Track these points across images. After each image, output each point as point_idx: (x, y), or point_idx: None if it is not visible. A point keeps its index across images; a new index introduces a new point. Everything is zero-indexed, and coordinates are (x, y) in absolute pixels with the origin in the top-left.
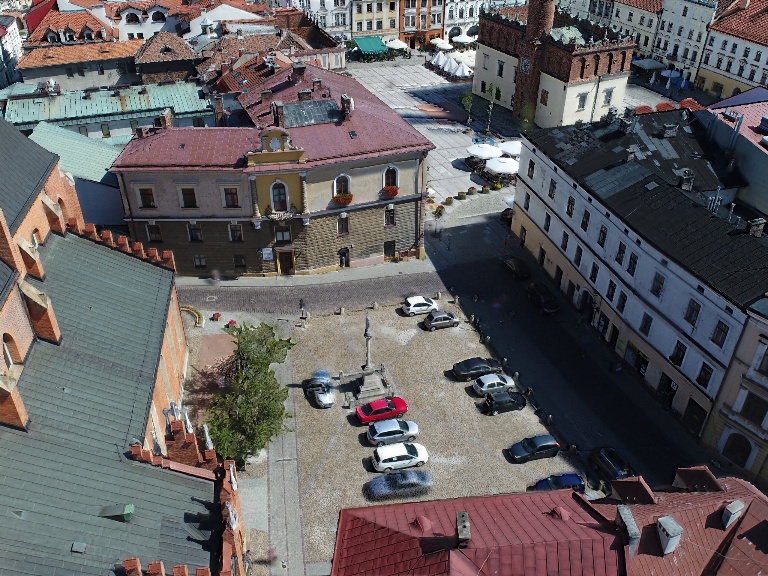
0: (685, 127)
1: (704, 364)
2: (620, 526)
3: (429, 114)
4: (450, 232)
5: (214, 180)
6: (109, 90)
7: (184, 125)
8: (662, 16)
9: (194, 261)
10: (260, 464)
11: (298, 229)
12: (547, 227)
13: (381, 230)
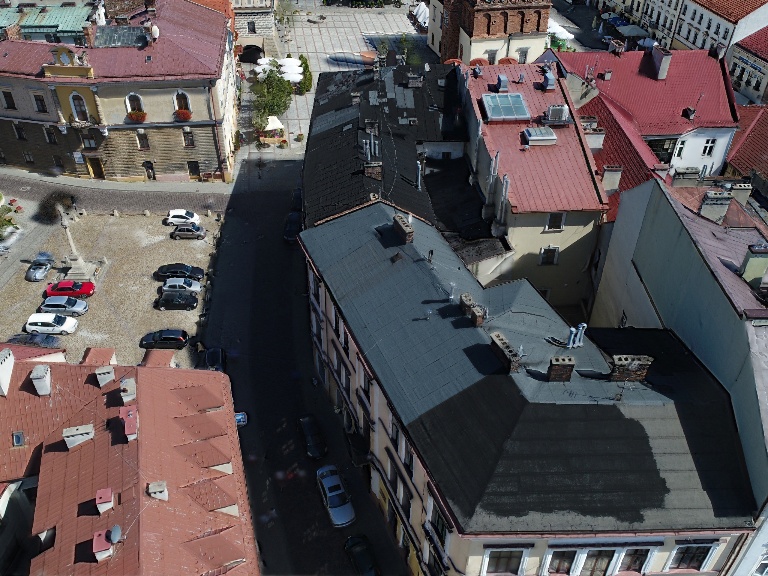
0: (440, 80)
1: None
2: None
3: (365, 60)
4: (276, 164)
5: (24, 86)
6: (18, 7)
7: (67, 42)
8: None
9: (25, 157)
10: None
11: (100, 138)
12: None
13: (182, 150)
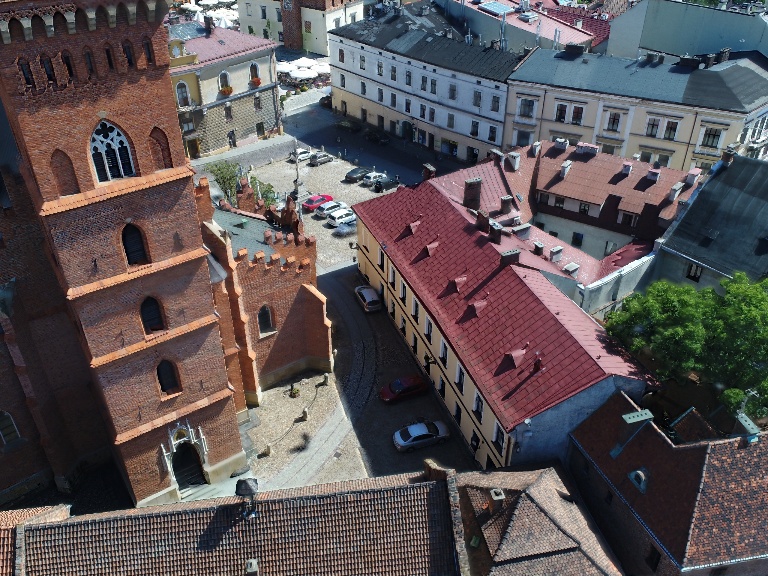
0: (432, 9)
1: (491, 127)
2: (494, 158)
3: None
4: (290, 119)
5: None
6: None
7: None
8: None
9: None
10: None
11: (199, 119)
12: (363, 92)
13: (253, 114)
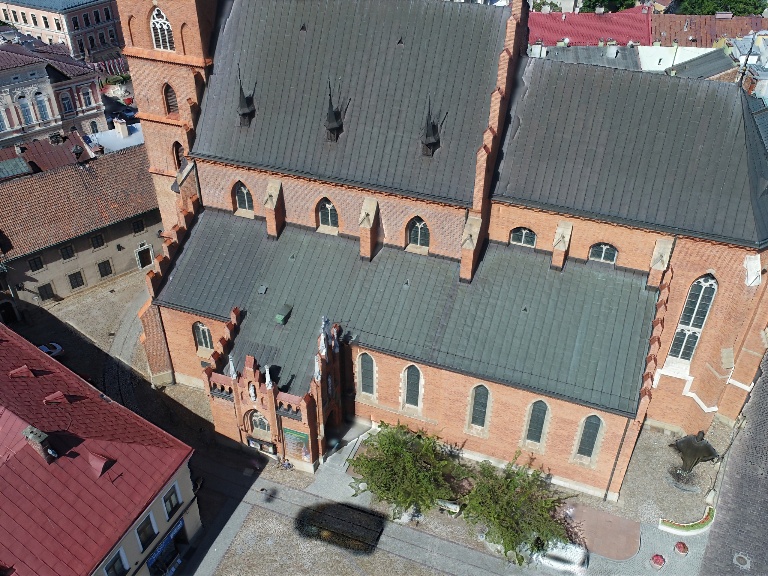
0: None
1: None
2: None
3: None
4: None
5: None
6: None
7: None
8: None
9: None
10: (388, 511)
11: None
12: None
13: None
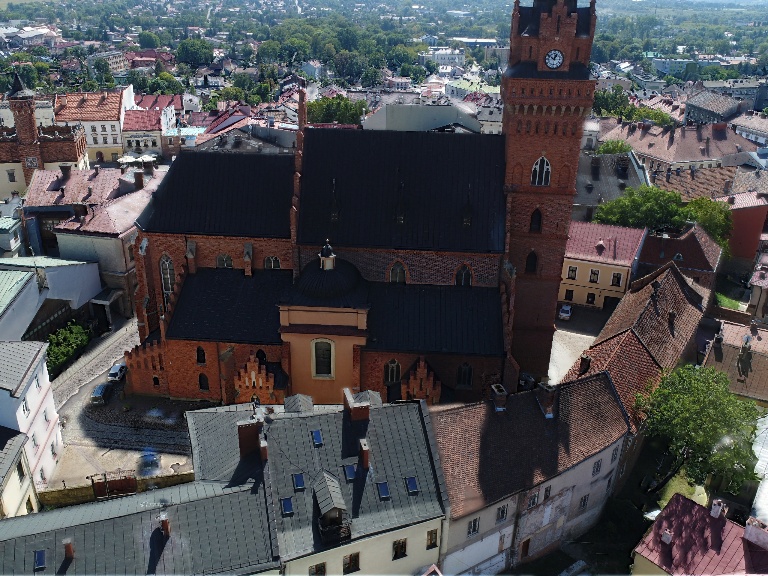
0: None
1: None
2: None
3: None
4: None
5: None
6: None
7: (11, 238)
8: (4, 124)
9: None
10: None
11: None
12: None
13: None
